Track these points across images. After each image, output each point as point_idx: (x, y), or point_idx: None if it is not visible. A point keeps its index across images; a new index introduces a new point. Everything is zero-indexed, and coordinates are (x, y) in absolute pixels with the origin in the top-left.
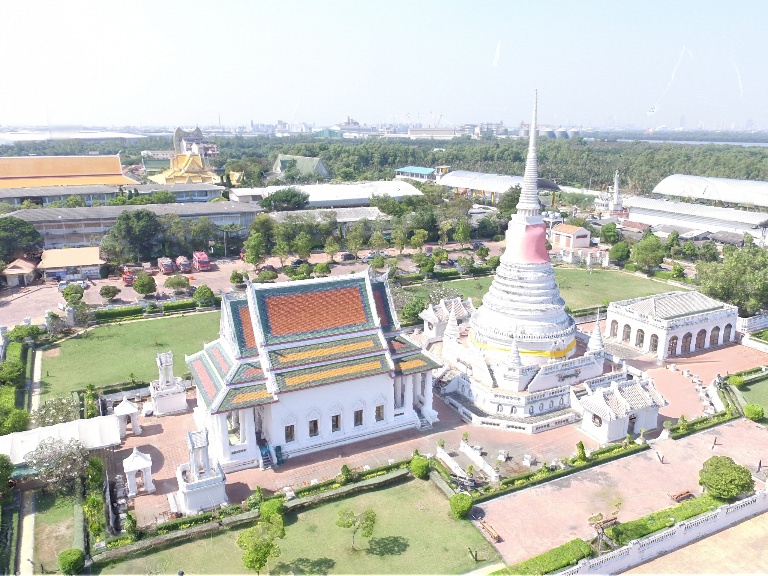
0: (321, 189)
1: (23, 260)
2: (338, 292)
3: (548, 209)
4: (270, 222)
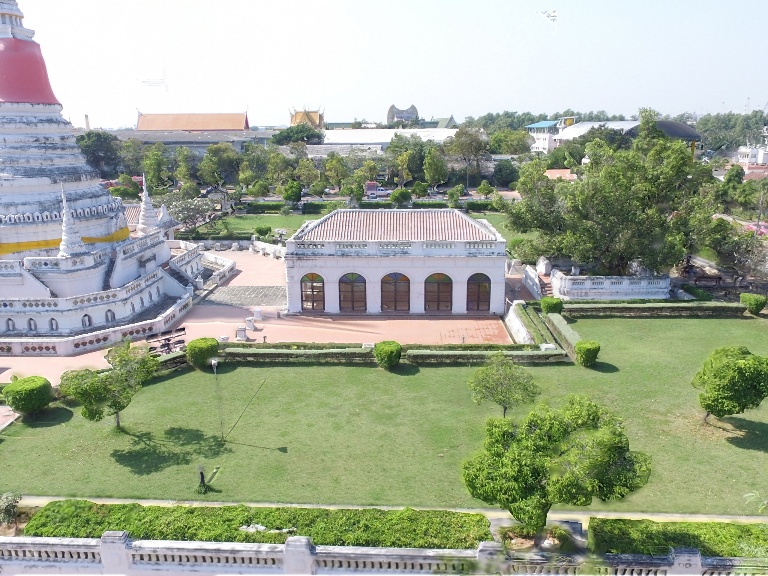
0: (363, 132)
1: None
2: None
3: None
4: (227, 151)
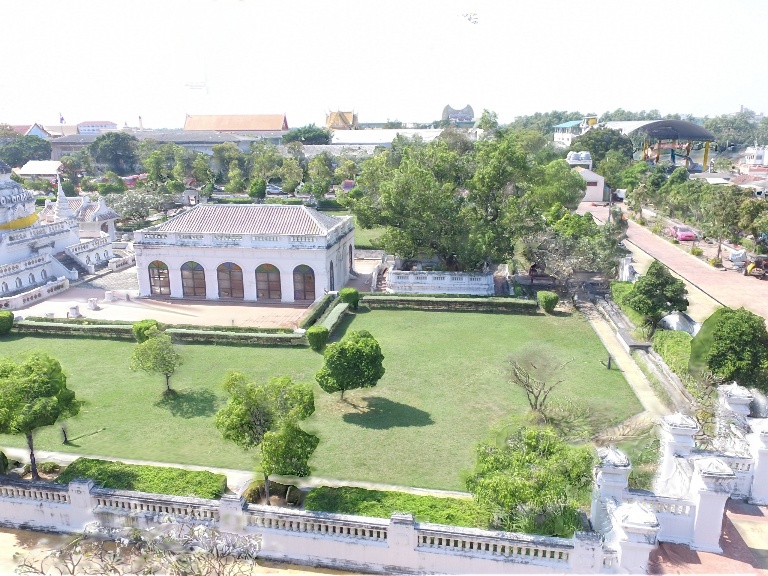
0: (374, 132)
1: (20, 168)
2: None
3: (610, 153)
4: (230, 151)
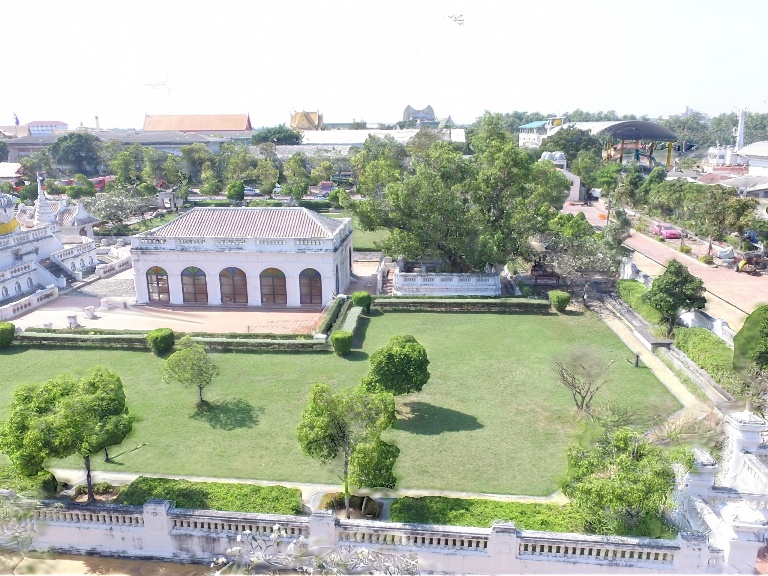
0: (344, 133)
1: None
2: None
3: (581, 153)
4: (200, 152)
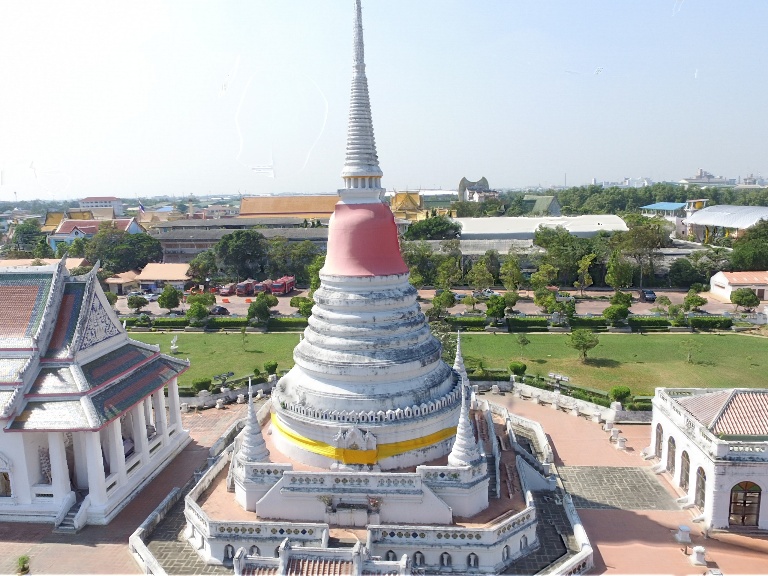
0: (493, 221)
1: (134, 272)
2: (8, 289)
3: None
4: None
